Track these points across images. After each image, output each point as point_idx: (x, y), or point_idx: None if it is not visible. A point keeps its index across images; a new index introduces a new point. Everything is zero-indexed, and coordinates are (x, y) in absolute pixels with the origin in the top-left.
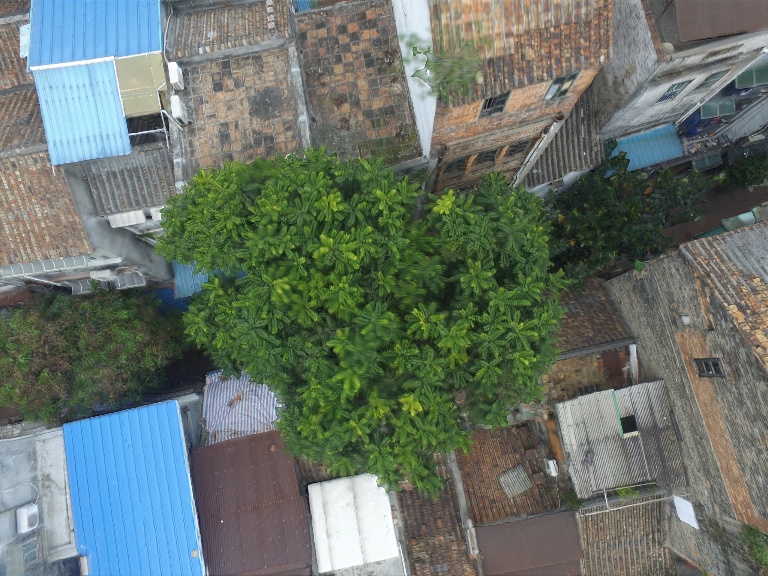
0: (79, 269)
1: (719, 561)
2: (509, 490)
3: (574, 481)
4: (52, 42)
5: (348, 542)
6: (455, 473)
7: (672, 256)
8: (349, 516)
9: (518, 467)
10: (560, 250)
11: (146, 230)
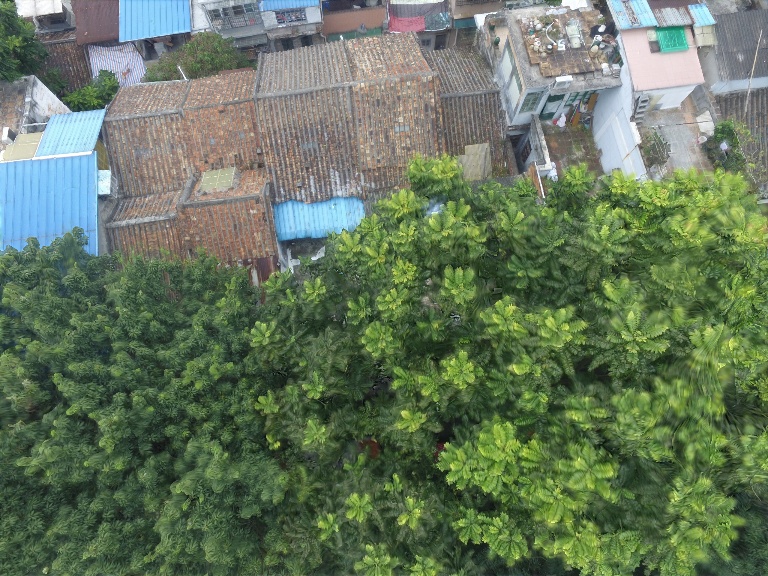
0: None
1: None
2: None
3: None
4: (79, 175)
5: None
6: None
7: None
8: None
9: None
10: None
11: None
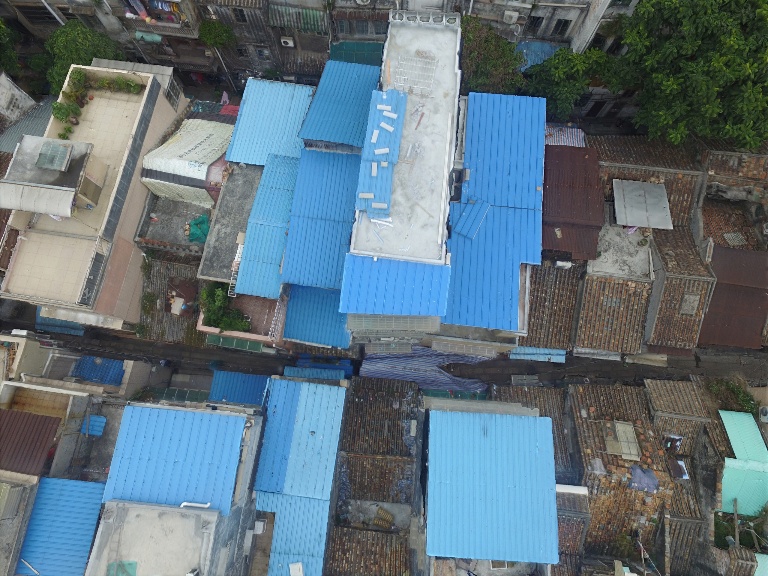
0: (496, 8)
1: None
2: (730, 242)
3: None
4: None
5: (639, 214)
6: (699, 215)
7: None
8: (640, 201)
9: (738, 232)
10: None
11: (537, 2)
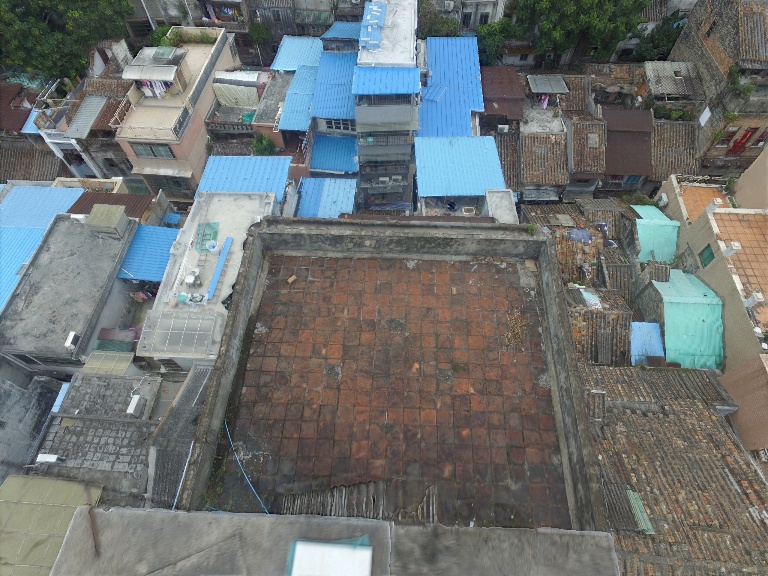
0: (440, 1)
1: (720, 113)
2: None
3: (651, 88)
4: None
5: None
6: (591, 99)
7: (697, 2)
8: None
9: None
10: (645, 48)
11: (465, 0)
